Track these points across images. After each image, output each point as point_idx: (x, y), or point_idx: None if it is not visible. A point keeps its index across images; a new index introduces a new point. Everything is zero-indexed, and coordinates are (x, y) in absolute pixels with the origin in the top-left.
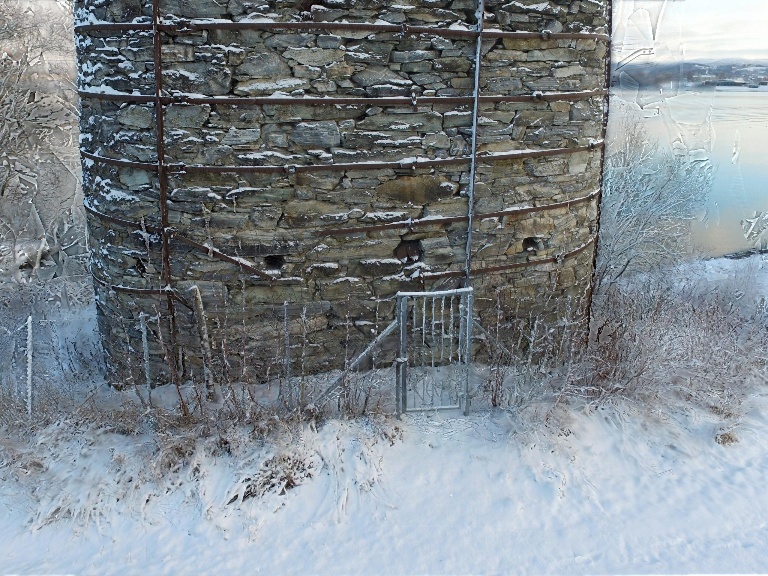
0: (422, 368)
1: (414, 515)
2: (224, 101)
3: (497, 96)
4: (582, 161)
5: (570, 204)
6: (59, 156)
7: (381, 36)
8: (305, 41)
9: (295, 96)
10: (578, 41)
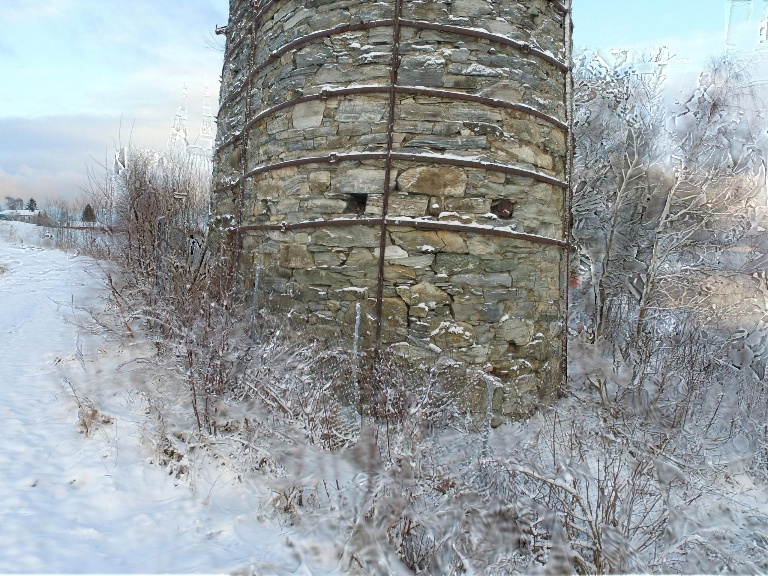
0: None
1: None
2: None
3: None
4: (315, 113)
5: (296, 164)
6: (576, 237)
7: None
8: None
9: None
10: None
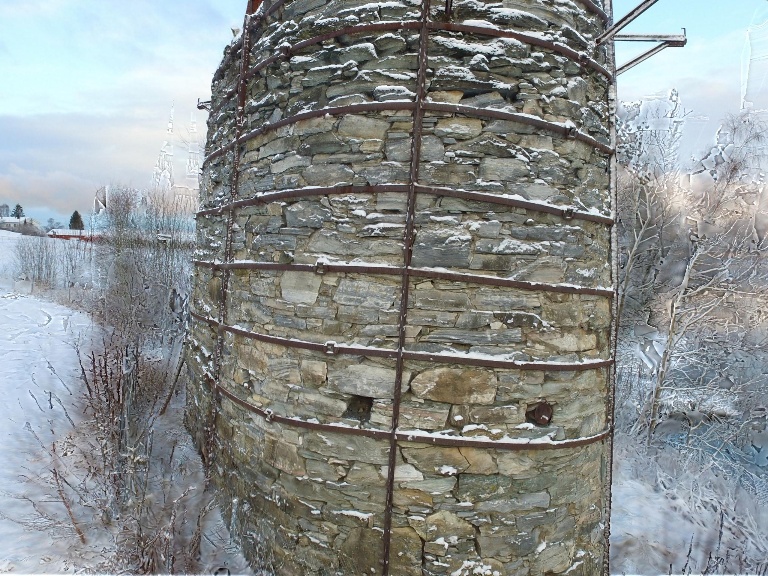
0: (200, 471)
1: (13, 504)
2: None
3: None
4: (308, 287)
5: (284, 343)
6: None
7: None
8: None
9: None
10: (296, 125)
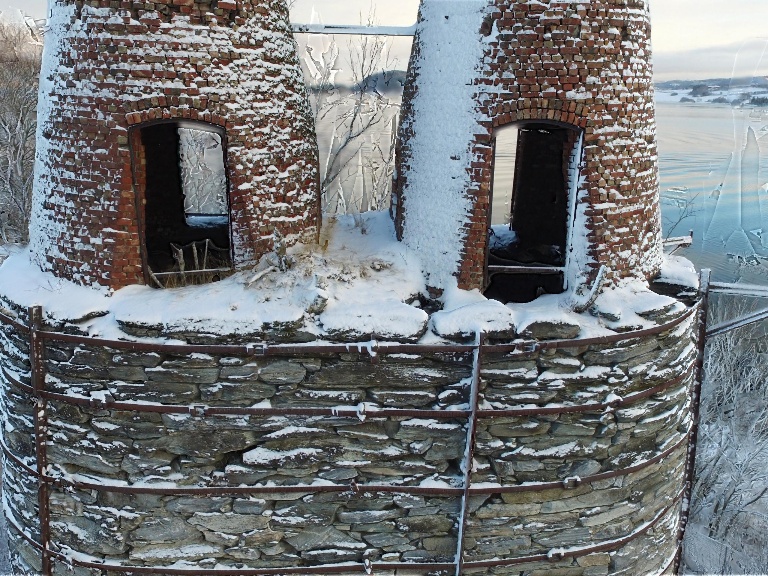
0: None
1: None
2: (115, 568)
3: (491, 560)
4: None
5: None
6: None
7: (321, 497)
8: (218, 505)
9: (204, 565)
10: (627, 476)
